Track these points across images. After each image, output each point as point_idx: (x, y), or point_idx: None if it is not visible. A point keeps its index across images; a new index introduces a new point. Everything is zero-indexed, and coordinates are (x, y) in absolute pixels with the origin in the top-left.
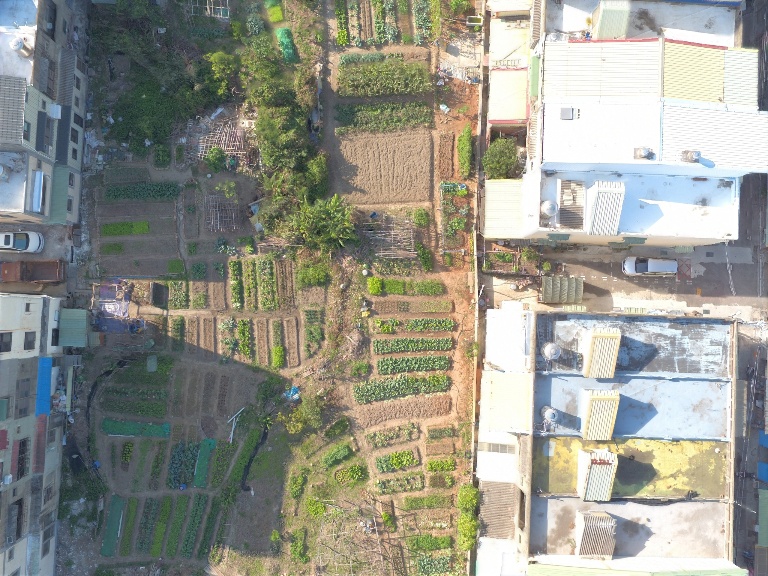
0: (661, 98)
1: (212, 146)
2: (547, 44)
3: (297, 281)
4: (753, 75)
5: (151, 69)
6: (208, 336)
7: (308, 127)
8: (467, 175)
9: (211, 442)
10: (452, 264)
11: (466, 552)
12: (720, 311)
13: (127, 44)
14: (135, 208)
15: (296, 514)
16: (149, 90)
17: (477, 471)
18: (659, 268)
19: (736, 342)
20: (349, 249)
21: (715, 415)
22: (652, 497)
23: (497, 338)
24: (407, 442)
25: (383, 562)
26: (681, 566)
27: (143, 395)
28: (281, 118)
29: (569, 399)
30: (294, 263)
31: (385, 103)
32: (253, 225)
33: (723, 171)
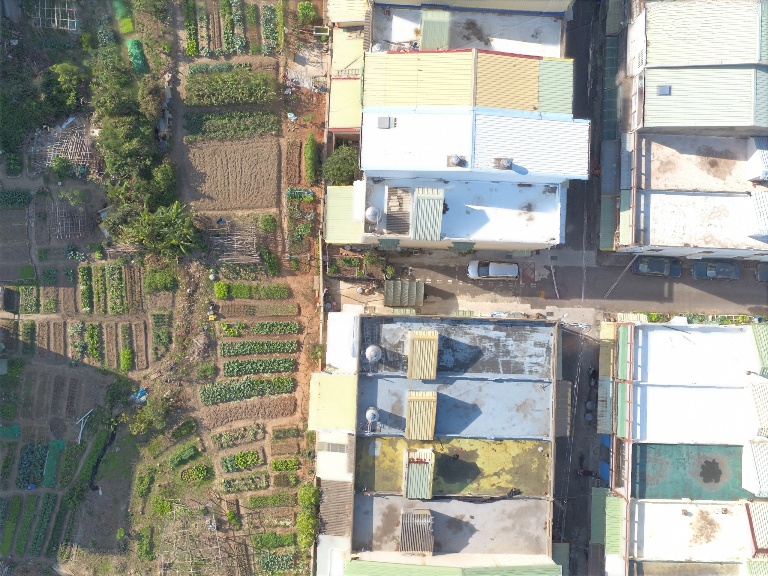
0: (473, 107)
1: (59, 155)
2: (367, 55)
3: (145, 286)
4: (568, 84)
5: (2, 80)
6: (58, 340)
7: (156, 136)
8: (313, 182)
9: (60, 443)
10: (298, 268)
11: (310, 549)
12: (563, 313)
13: None
14: None
15: (143, 513)
16: (1, 100)
17: (317, 470)
18: (500, 271)
19: (556, 344)
20: (197, 254)
21: (538, 415)
22: (474, 495)
23: (336, 341)
24: (253, 442)
25: (227, 559)
26: (497, 562)
27: None
28: (124, 127)
29: (395, 400)
30: (143, 268)
31: (233, 112)
32: (102, 231)
33: (540, 177)
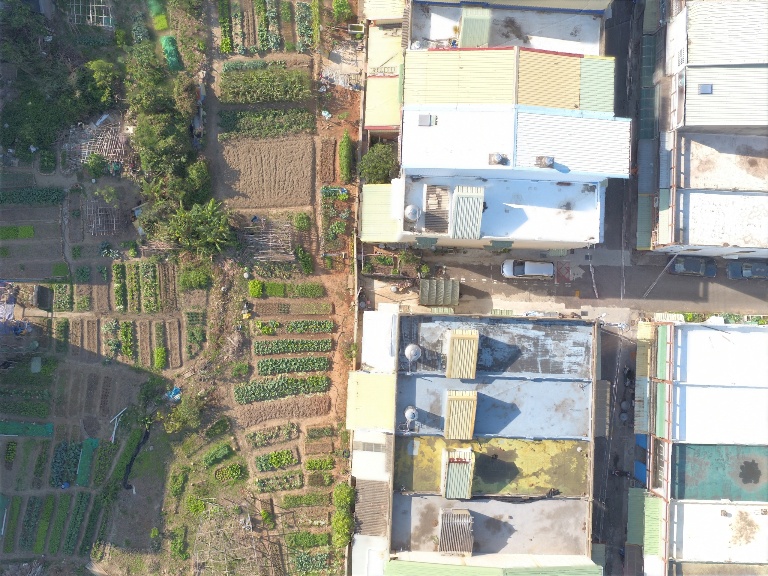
0: (515, 105)
1: (94, 152)
2: (408, 52)
3: (179, 284)
4: (609, 82)
5: (36, 77)
6: (92, 338)
7: (190, 133)
8: (348, 180)
9: (93, 441)
10: (332, 267)
11: (344, 549)
12: (598, 313)
13: (8, 52)
14: (21, 213)
15: (177, 512)
16: (35, 97)
17: (352, 470)
18: (536, 271)
19: (596, 343)
20: (231, 252)
21: (577, 415)
22: (513, 495)
23: (372, 339)
24: (287, 441)
25: (262, 559)
26: (537, 562)
27: (26, 395)
28: (160, 124)
29: (433, 399)
30: (177, 266)
31: (267, 109)
32: (136, 229)
33: (581, 176)
